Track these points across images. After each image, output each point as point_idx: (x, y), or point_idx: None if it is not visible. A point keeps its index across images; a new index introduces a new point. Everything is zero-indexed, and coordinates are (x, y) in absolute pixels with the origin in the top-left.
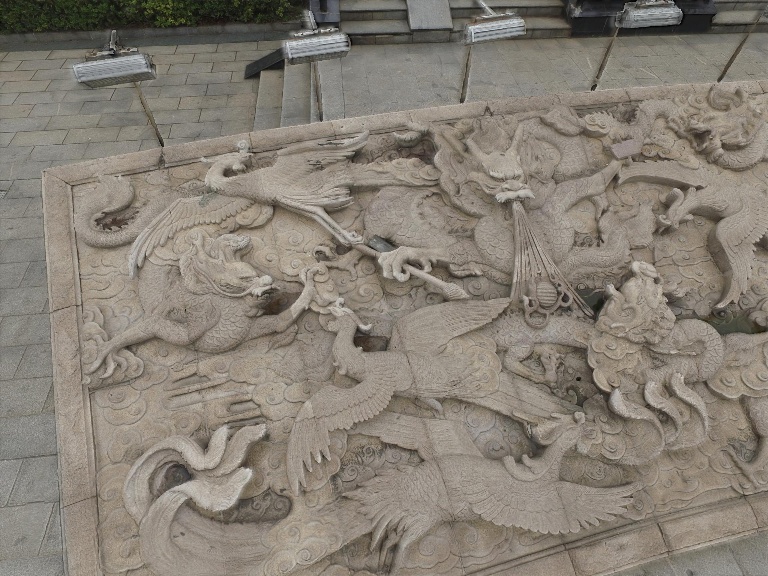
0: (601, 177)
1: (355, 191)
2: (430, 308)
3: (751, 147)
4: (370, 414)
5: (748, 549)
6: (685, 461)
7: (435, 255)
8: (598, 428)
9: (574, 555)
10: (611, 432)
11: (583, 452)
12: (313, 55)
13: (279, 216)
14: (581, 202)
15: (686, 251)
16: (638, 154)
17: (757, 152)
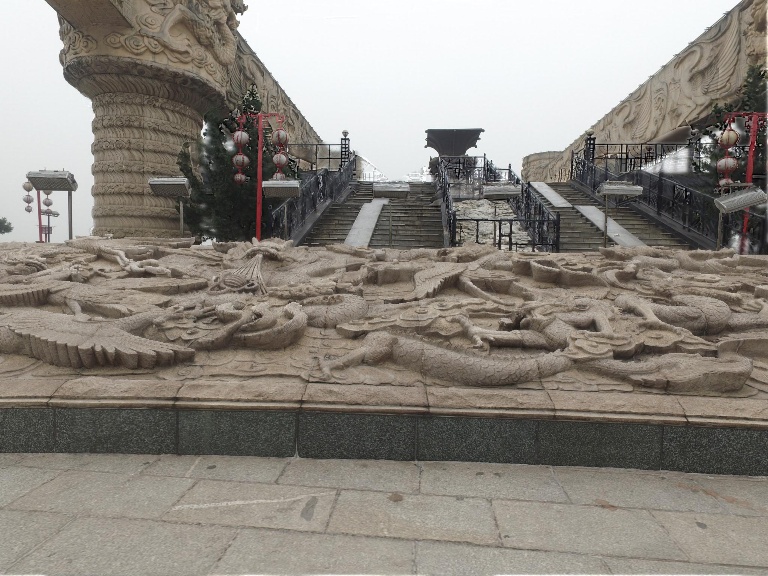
0: (344, 259)
1: (160, 257)
2: (137, 278)
3: (481, 257)
4: (14, 293)
5: (312, 465)
6: (267, 359)
7: (174, 266)
8: (194, 324)
9: (69, 380)
10: (204, 328)
11: (156, 320)
12: (162, 184)
13: (98, 262)
14: (327, 275)
15: (394, 292)
16: (383, 255)
17: (483, 258)
